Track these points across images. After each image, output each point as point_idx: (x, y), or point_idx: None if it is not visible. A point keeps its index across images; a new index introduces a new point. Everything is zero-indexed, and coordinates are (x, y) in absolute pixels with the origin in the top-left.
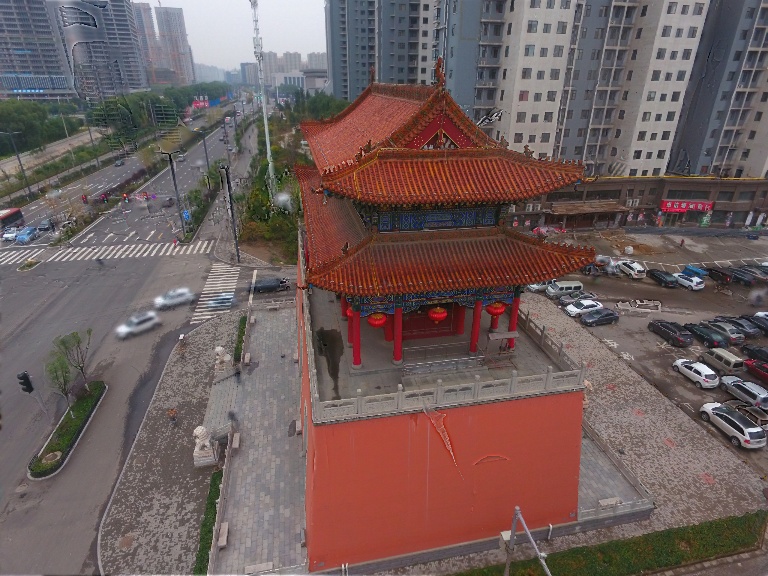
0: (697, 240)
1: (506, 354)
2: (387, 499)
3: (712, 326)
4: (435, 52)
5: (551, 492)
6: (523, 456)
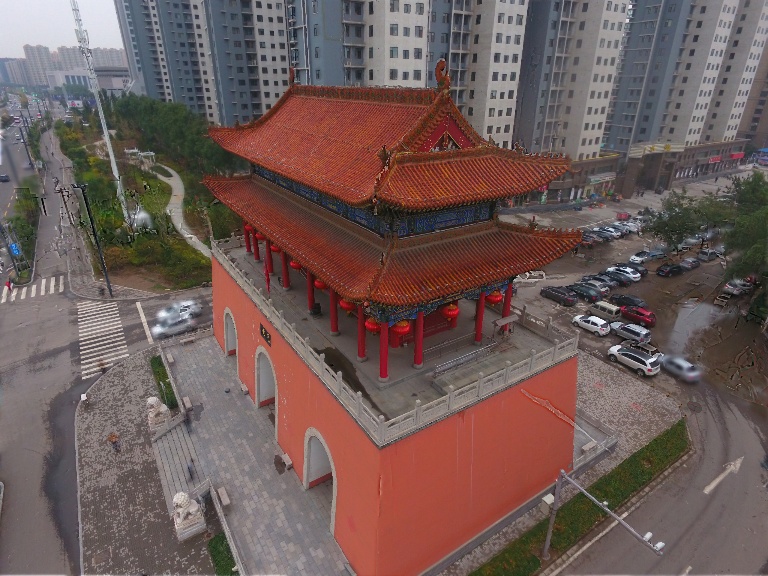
0: (542, 216)
1: (508, 337)
2: (440, 502)
3: (585, 285)
4: (294, 52)
5: (556, 451)
6: (538, 425)
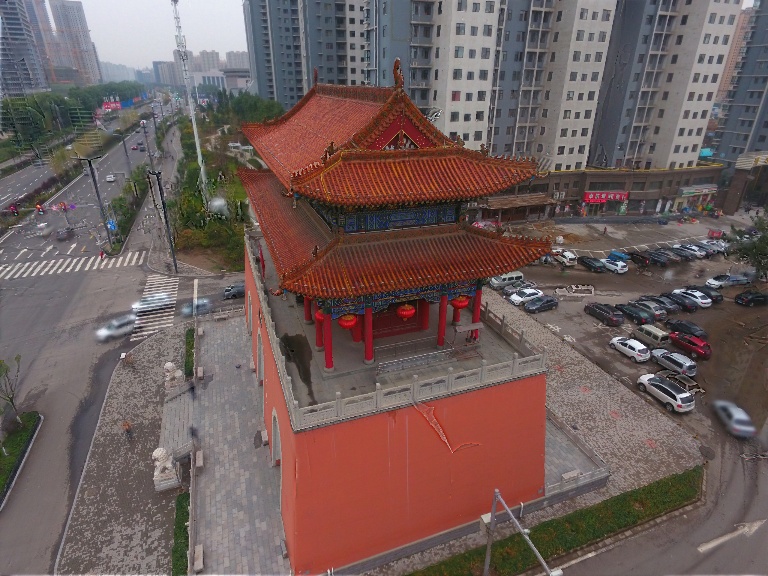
0: (617, 227)
1: (472, 345)
2: (369, 498)
3: (639, 305)
4: (367, 53)
5: (521, 472)
6: (495, 441)
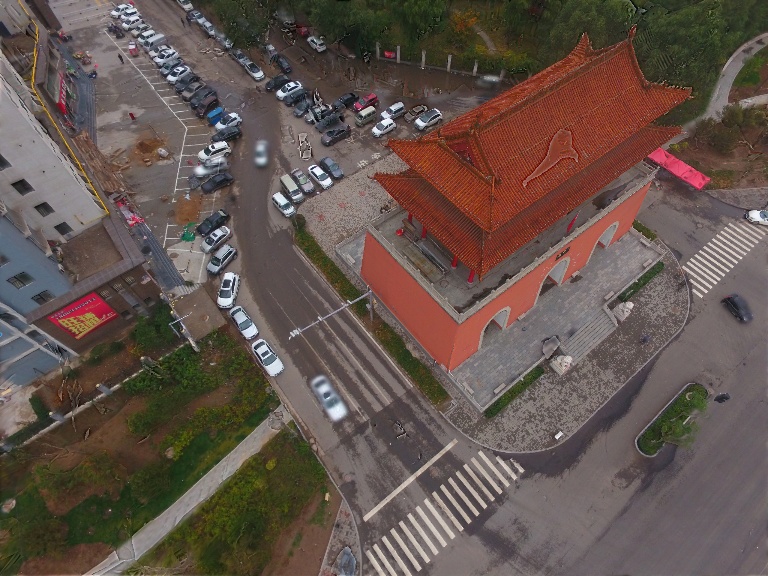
0: (108, 109)
1: None
2: None
3: None
4: None
5: None
6: None
